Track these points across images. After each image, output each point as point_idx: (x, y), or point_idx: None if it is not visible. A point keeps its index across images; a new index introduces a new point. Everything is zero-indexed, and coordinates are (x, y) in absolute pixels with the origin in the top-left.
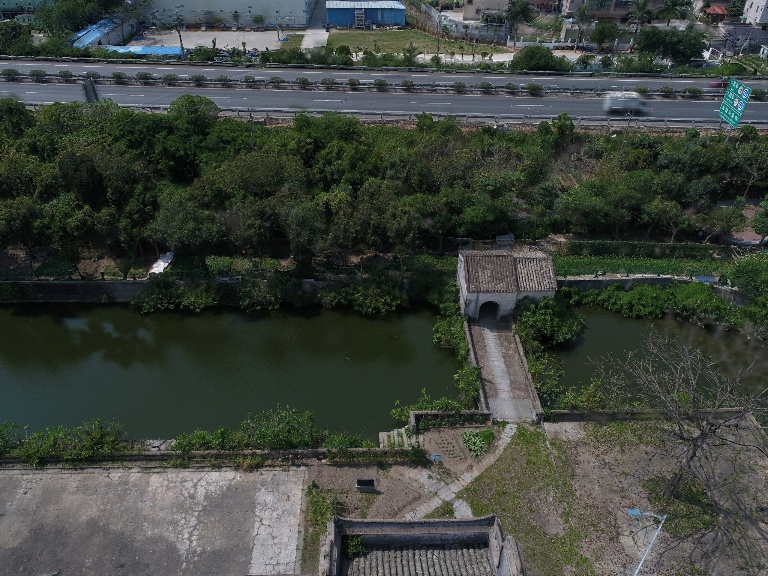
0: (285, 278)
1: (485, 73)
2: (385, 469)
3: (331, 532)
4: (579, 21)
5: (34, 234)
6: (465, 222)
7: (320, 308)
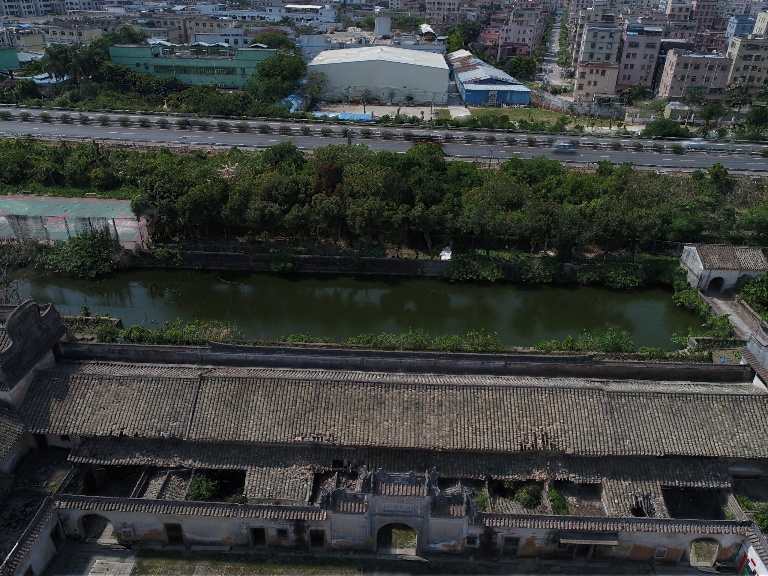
0: (553, 261)
1: (626, 138)
2: None
3: (761, 331)
4: (690, 102)
5: (380, 222)
6: (674, 230)
7: (578, 284)
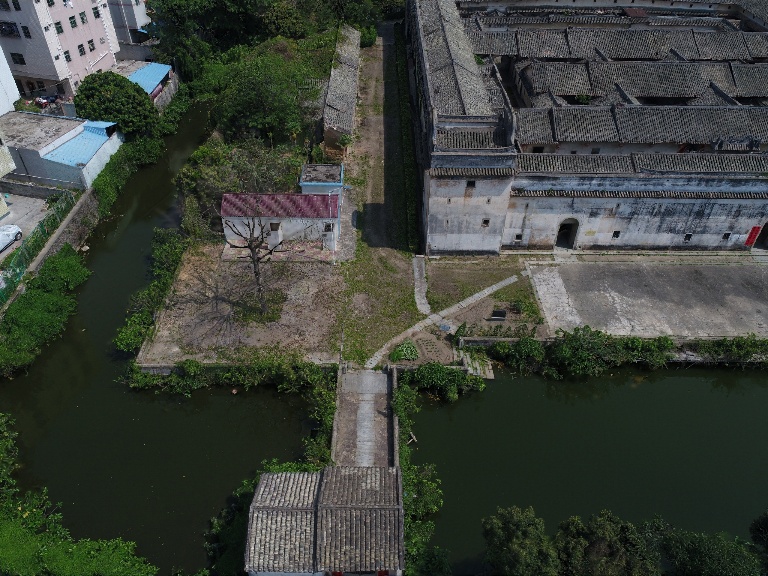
0: None
1: None
2: None
3: None
4: None
5: None
6: None
7: None
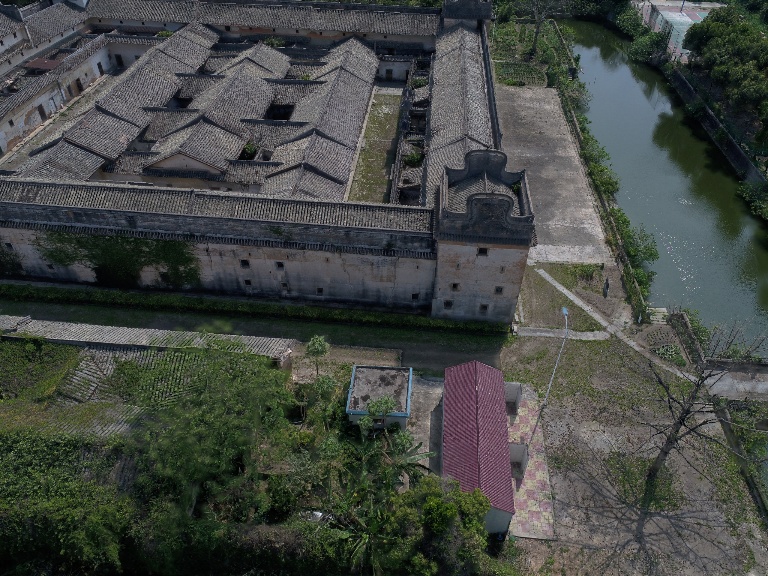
0: None
1: None
2: (626, 301)
3: None
4: None
5: (759, 110)
6: None
7: None
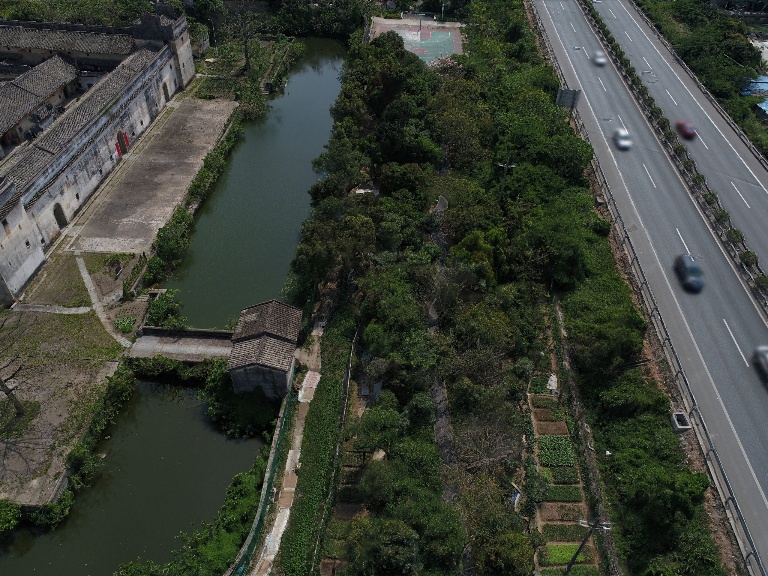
0: None
1: None
2: None
3: None
4: None
5: None
6: None
7: None
